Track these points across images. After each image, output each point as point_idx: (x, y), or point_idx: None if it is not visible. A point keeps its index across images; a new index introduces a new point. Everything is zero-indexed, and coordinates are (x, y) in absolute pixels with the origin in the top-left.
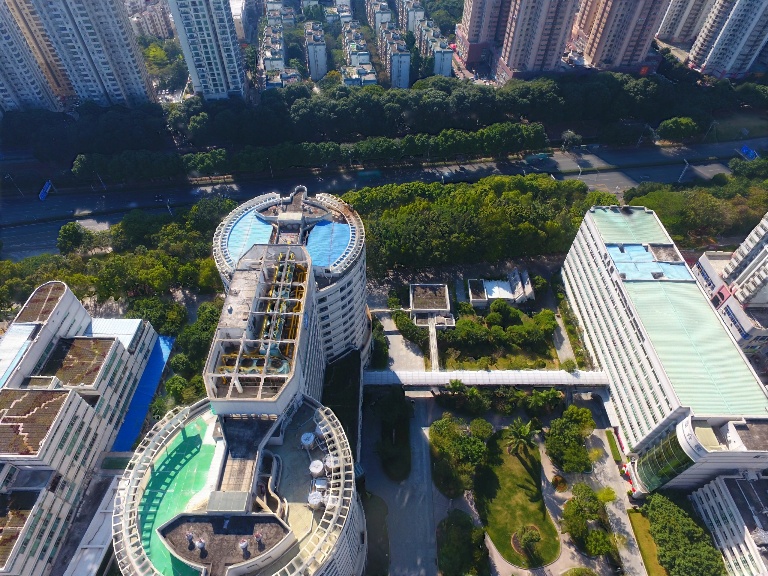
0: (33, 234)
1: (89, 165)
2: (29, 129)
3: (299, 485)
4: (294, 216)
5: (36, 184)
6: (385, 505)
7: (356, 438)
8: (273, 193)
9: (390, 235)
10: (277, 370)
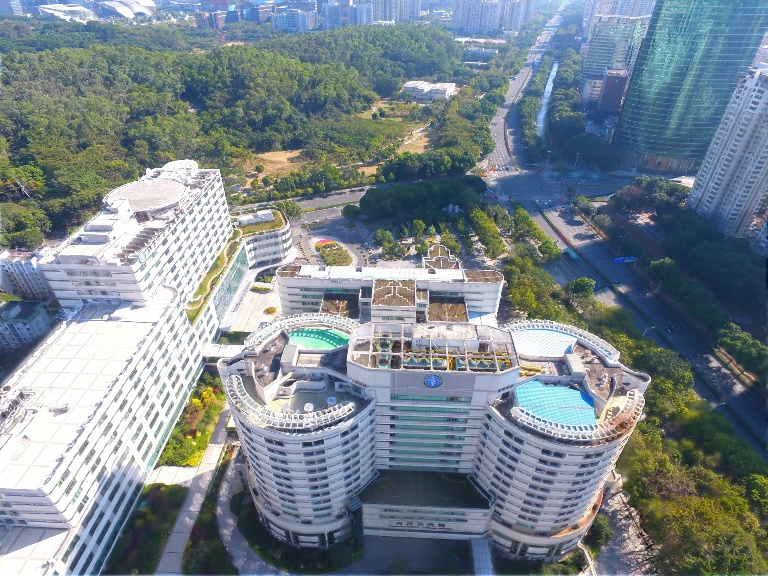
0: (581, 271)
1: (664, 268)
2: (683, 226)
3: (302, 404)
4: (577, 366)
5: (630, 254)
6: (341, 560)
7: (385, 502)
8: (618, 352)
9: (725, 567)
10: (378, 363)
